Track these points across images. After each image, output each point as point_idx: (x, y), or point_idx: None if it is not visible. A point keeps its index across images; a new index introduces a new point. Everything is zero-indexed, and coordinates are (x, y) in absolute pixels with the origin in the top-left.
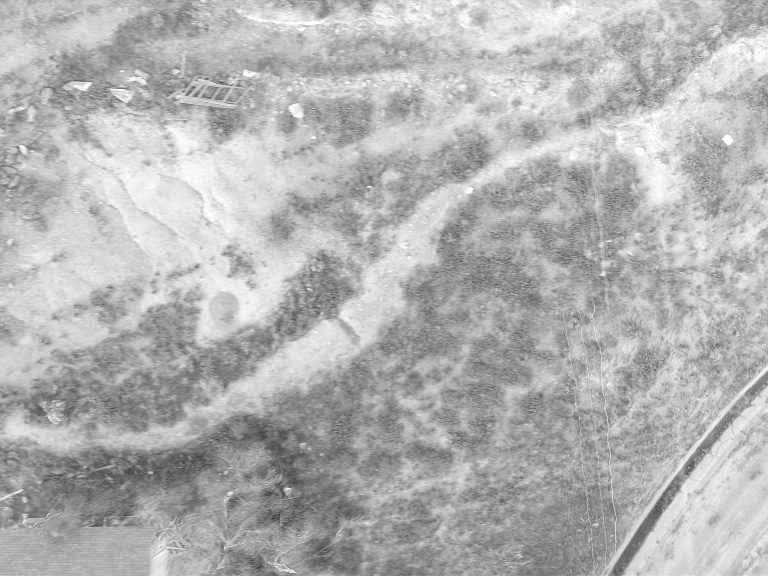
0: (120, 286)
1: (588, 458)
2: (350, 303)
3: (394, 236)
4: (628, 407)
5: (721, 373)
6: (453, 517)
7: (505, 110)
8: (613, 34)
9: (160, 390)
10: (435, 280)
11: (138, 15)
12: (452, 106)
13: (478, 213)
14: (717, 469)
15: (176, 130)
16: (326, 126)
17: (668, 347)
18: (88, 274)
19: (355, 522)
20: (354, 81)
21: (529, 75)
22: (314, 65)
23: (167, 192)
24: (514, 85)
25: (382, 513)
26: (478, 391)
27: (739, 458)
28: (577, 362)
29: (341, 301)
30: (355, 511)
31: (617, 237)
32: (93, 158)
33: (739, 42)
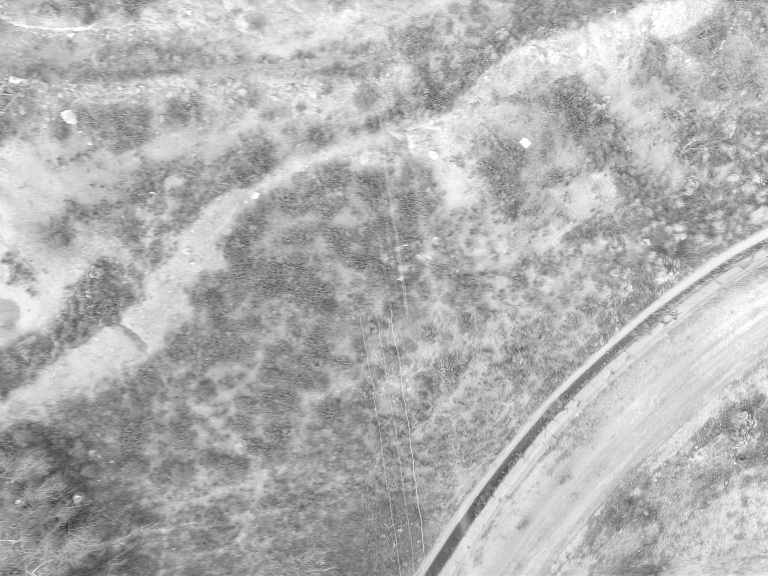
0: None
1: (390, 463)
2: (132, 310)
3: (176, 242)
4: (429, 412)
5: (528, 377)
6: (253, 524)
7: (290, 115)
8: (400, 37)
9: None
10: (223, 286)
11: None
12: (235, 111)
13: (268, 218)
14: (527, 473)
15: None
16: (102, 132)
17: (470, 351)
18: None
19: (147, 530)
20: (127, 87)
21: (311, 79)
22: (84, 71)
23: None
24: (296, 89)
25: (178, 520)
26: (273, 397)
27: (549, 462)
28: (375, 367)
29: (122, 308)
30: (149, 518)
31: (414, 241)
32: None
33: (530, 45)
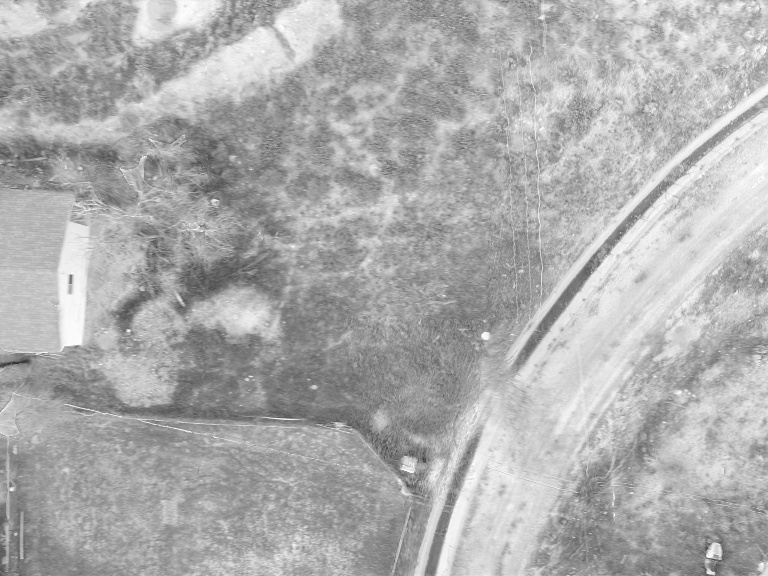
0: None
1: (517, 202)
2: (286, 12)
3: None
4: (560, 153)
5: (656, 132)
6: (379, 250)
7: None
8: None
9: (94, 85)
10: (373, 2)
11: None
12: None
13: None
14: (647, 230)
15: None
16: None
17: (603, 98)
18: None
19: (280, 239)
20: None
21: None
22: None
23: None
24: None
25: (309, 238)
26: (410, 121)
27: (670, 221)
28: (511, 102)
29: (277, 9)
30: (281, 231)
31: None
32: None
33: None
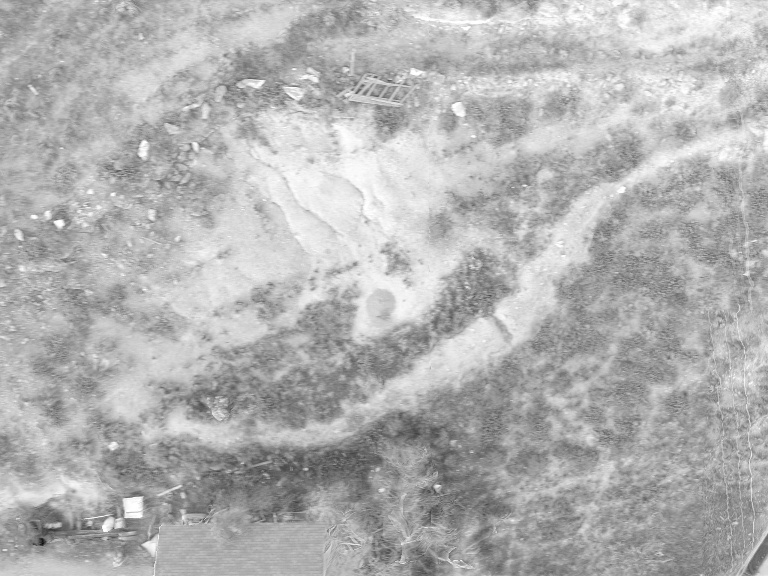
0: (280, 283)
1: (729, 457)
2: (506, 301)
3: (550, 235)
4: None
5: None
6: (596, 515)
7: (658, 110)
8: (765, 35)
9: (317, 387)
10: (586, 279)
11: (309, 13)
12: (607, 106)
13: (628, 212)
14: None
15: (342, 128)
16: (486, 125)
17: None
18: (250, 271)
19: (504, 519)
20: (516, 80)
21: (685, 75)
22: (478, 64)
23: (330, 190)
24: (669, 85)
25: (527, 511)
26: (625, 389)
27: None
28: (721, 361)
29: (497, 299)
30: (502, 508)
31: (762, 237)
32: (259, 155)
33: None
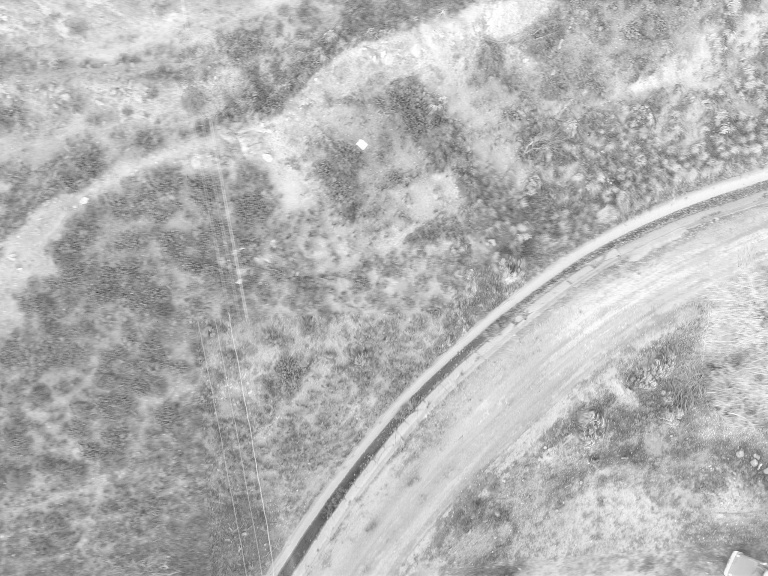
0: None
1: (232, 467)
2: None
3: (1, 248)
4: (271, 415)
5: (373, 379)
6: (94, 529)
7: (118, 119)
8: (227, 40)
9: None
10: (54, 291)
11: None
12: (60, 116)
13: (100, 223)
14: (376, 476)
15: None
16: None
17: (312, 354)
18: None
19: None
20: None
21: (135, 83)
22: None
23: None
24: (121, 94)
25: (17, 526)
26: (109, 402)
27: (397, 464)
28: (214, 371)
29: None
30: None
31: (251, 244)
32: None
33: (361, 46)
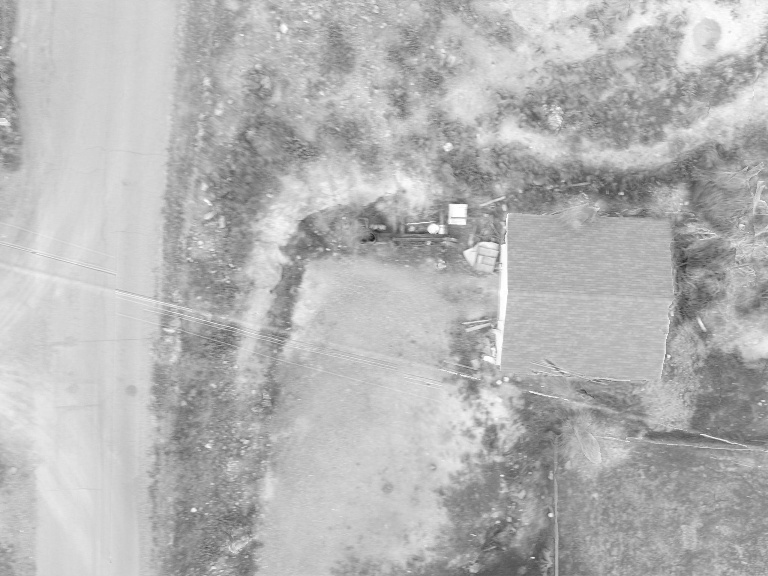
0: (615, 2)
1: None
2: None
3: None
4: None
5: None
6: None
7: None
8: None
9: (640, 111)
10: None
11: None
12: None
13: None
14: None
15: None
16: None
17: None
18: None
19: None
20: None
21: None
22: None
23: None
24: None
25: None
26: None
27: None
28: None
29: None
30: None
31: None
32: None
33: None
